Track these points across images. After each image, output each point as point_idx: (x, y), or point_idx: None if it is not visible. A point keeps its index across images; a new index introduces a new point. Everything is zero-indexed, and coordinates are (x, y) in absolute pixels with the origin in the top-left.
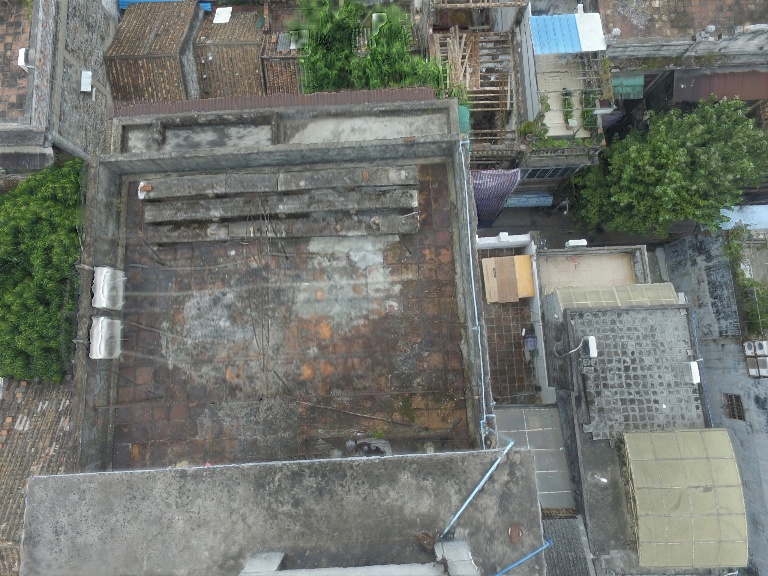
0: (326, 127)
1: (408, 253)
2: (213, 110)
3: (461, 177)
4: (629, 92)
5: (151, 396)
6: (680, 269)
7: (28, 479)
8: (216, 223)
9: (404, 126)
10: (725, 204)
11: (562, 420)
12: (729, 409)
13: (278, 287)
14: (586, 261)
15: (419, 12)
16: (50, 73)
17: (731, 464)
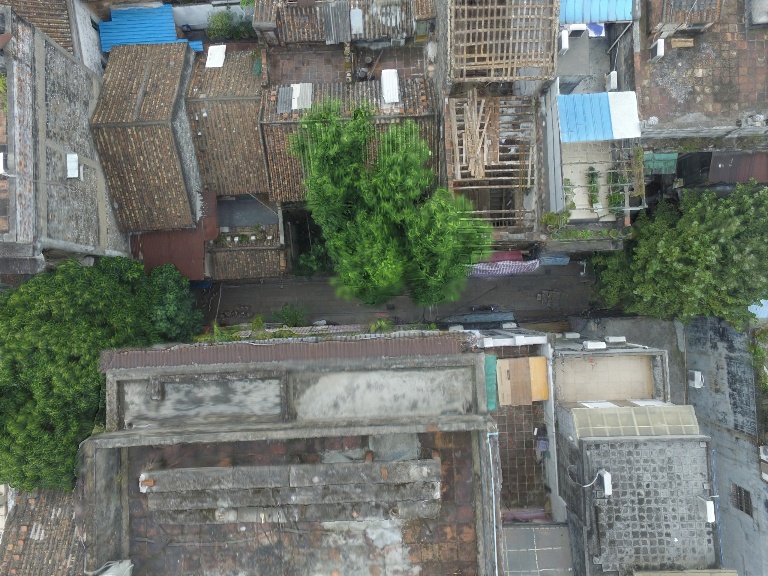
0: (339, 382)
1: (428, 532)
2: (215, 362)
3: (488, 473)
4: (661, 167)
5: None
6: (699, 346)
7: None
8: None
9: (425, 382)
10: (754, 303)
11: (572, 542)
12: (737, 499)
13: (292, 567)
14: (604, 361)
15: (433, 63)
16: (33, 173)
17: None
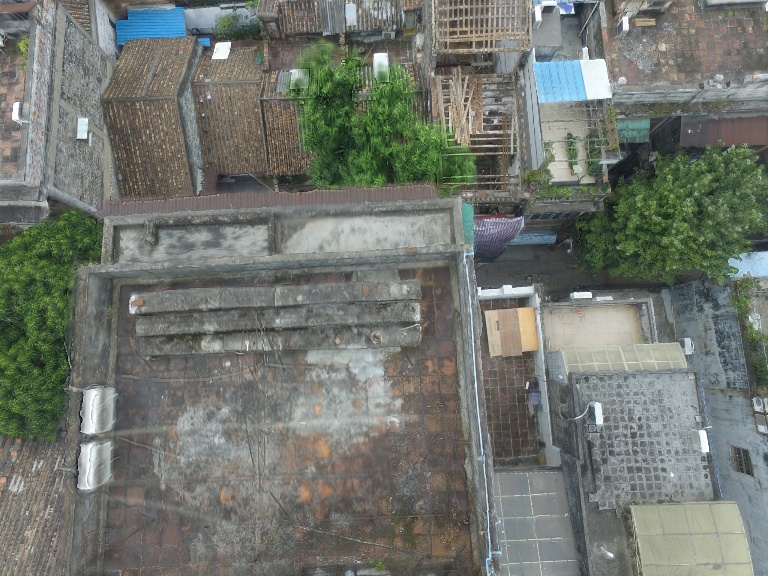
0: (325, 227)
1: (410, 365)
2: (208, 209)
3: (465, 291)
4: (635, 136)
5: (142, 519)
6: (686, 313)
7: (22, 545)
8: (210, 335)
9: (406, 226)
10: (733, 255)
11: (567, 485)
12: (737, 462)
13: (275, 401)
14: (591, 313)
15: (421, 50)
16: (45, 125)
17: (741, 540)
